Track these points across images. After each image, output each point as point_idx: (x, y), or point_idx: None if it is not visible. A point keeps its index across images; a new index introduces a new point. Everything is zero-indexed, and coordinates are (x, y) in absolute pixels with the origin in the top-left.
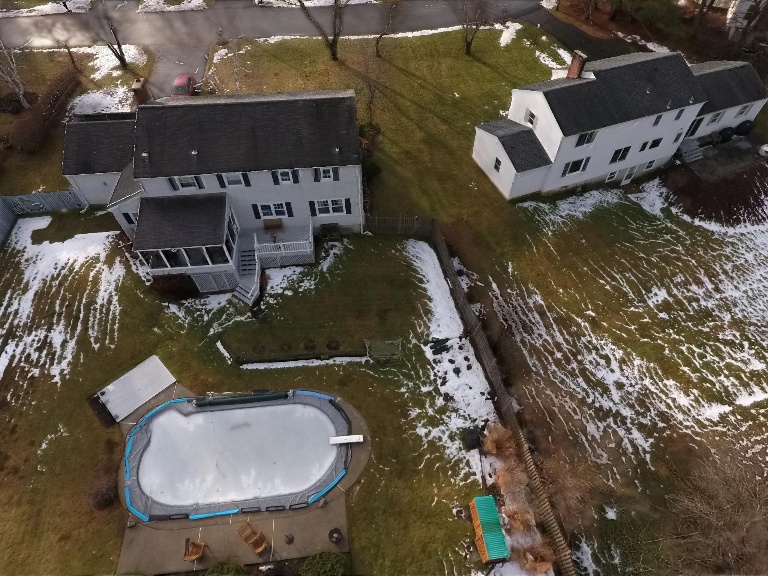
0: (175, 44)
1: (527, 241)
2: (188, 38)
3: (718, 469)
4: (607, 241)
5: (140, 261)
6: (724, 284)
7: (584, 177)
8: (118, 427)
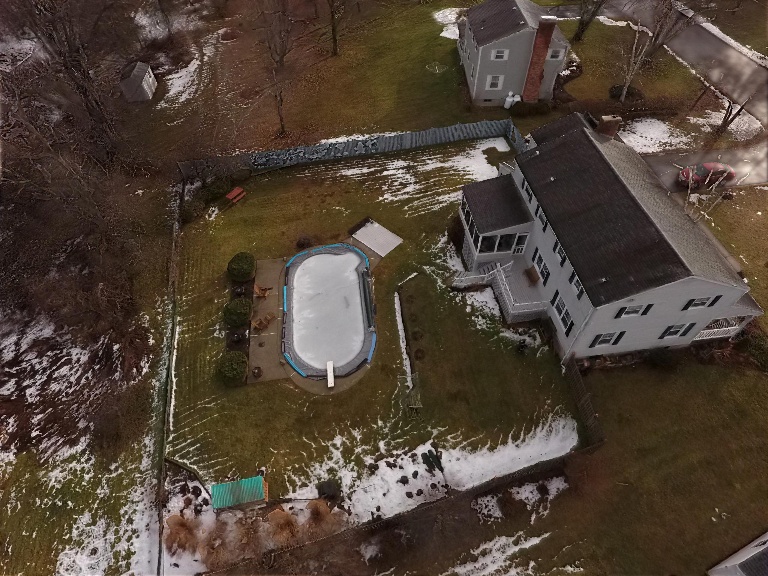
0: None
1: None
2: None
3: None
4: None
5: None
6: None
7: None
8: (349, 237)
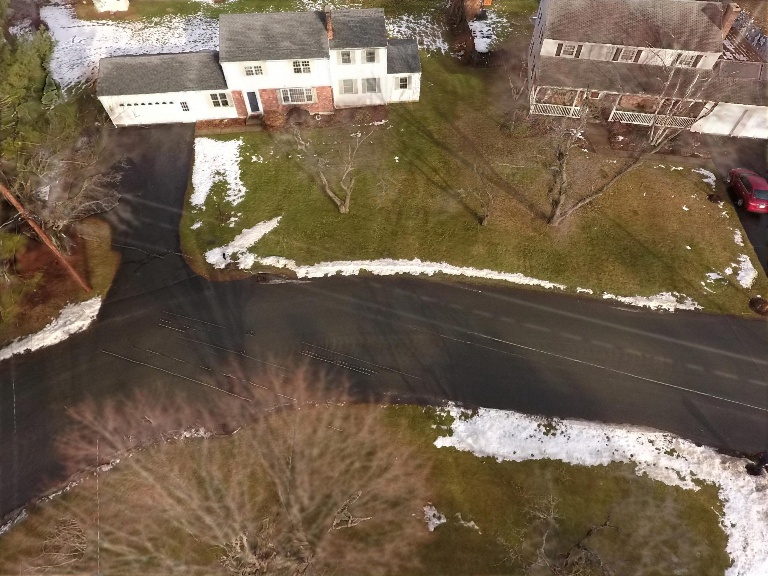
0: None
1: None
2: None
3: None
4: None
5: None
6: None
7: None
8: None
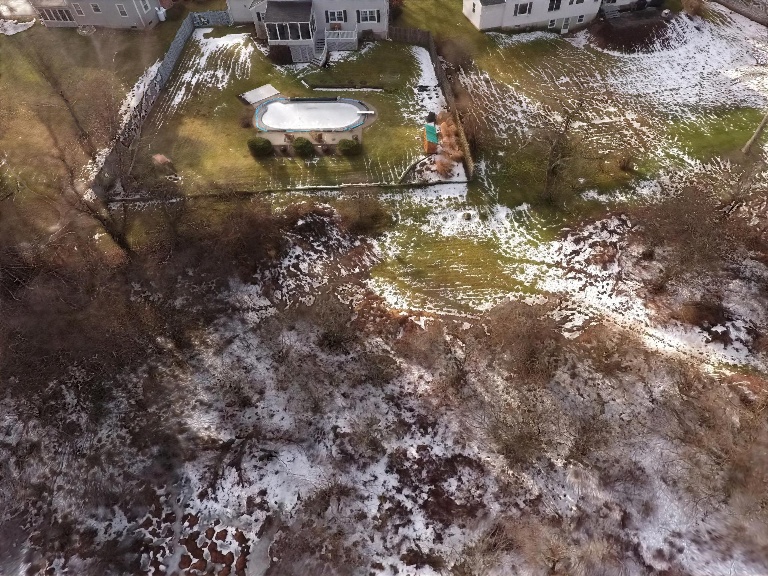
0: None
1: (487, 50)
2: None
3: (568, 143)
4: (539, 54)
5: (262, 45)
6: (609, 78)
7: (531, 20)
8: (251, 105)
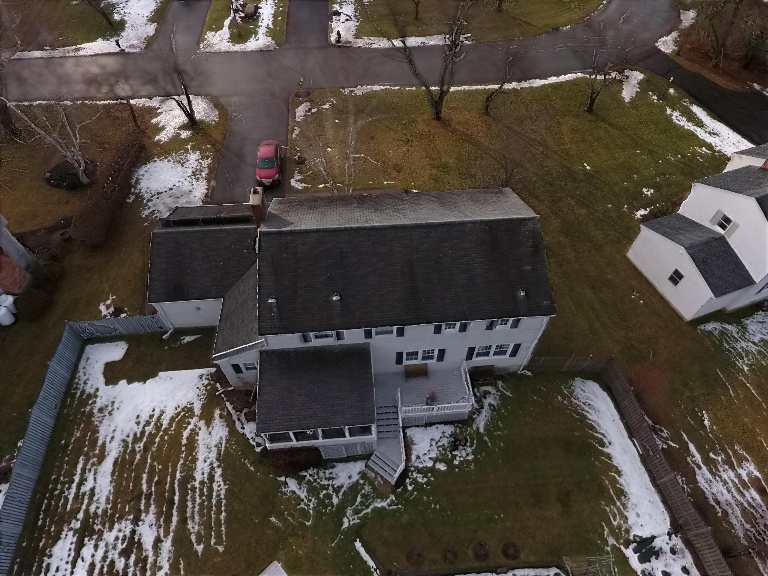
0: (248, 95)
1: (720, 380)
2: (262, 87)
3: None
4: None
5: (246, 415)
6: None
7: None
8: None
